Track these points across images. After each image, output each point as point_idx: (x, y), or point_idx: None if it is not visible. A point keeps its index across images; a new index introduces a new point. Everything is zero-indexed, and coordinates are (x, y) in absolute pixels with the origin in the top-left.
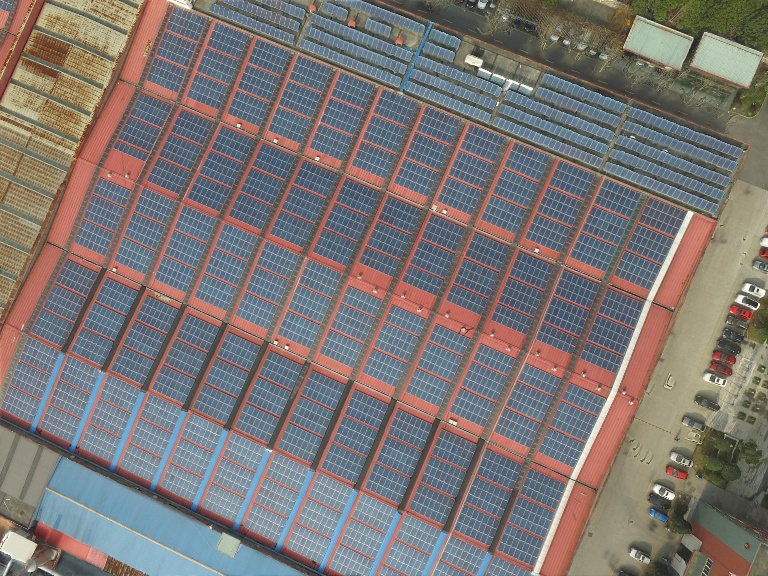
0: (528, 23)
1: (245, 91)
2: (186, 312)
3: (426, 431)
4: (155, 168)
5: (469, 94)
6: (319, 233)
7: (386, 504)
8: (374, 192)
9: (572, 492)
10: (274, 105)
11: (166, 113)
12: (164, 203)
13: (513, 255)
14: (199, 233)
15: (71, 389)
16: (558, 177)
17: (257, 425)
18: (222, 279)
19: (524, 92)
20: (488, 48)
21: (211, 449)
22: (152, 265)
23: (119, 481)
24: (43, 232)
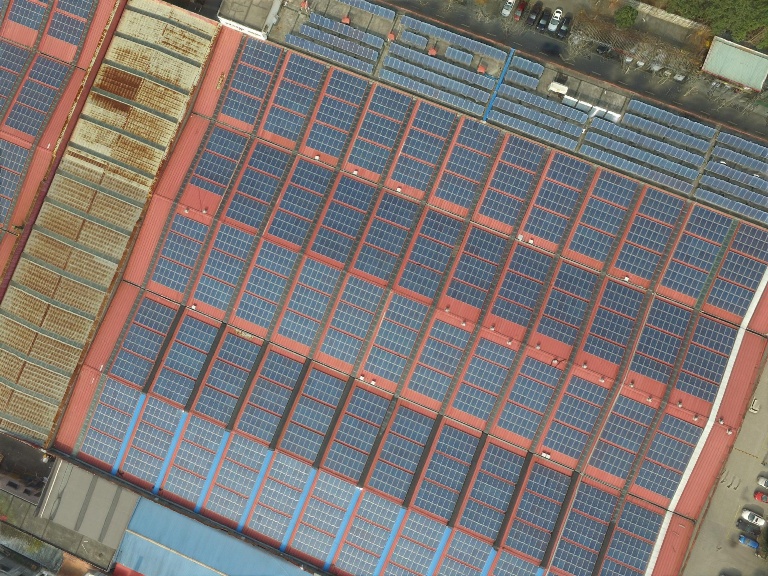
0: (602, 45)
1: (323, 122)
2: (268, 349)
3: (519, 465)
4: (233, 203)
5: (554, 122)
6: (404, 266)
7: (481, 541)
8: (458, 223)
9: (670, 524)
10: (353, 136)
11: (242, 146)
12: (244, 238)
13: (602, 284)
14: (280, 268)
15: (153, 430)
16: (647, 204)
17: (346, 463)
18: (305, 314)
19: (611, 119)
20: (571, 74)
21: (299, 488)
22: (232, 301)
23: (206, 523)
24: (120, 270)
